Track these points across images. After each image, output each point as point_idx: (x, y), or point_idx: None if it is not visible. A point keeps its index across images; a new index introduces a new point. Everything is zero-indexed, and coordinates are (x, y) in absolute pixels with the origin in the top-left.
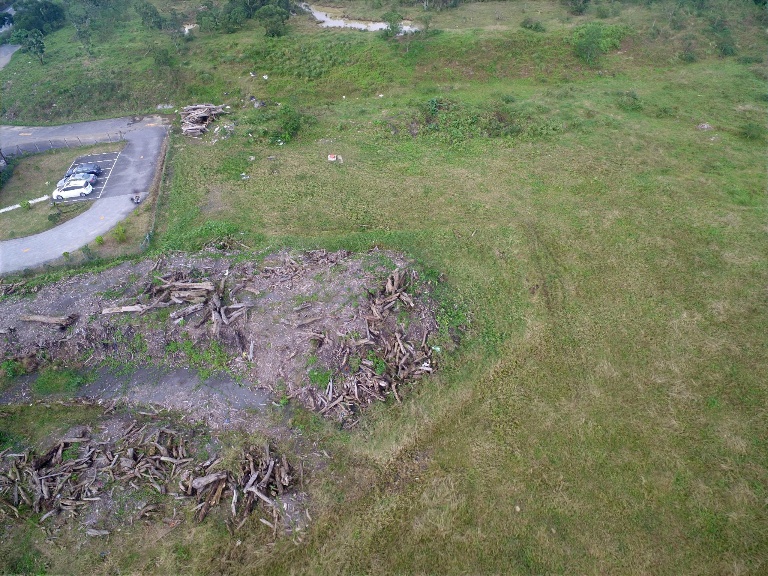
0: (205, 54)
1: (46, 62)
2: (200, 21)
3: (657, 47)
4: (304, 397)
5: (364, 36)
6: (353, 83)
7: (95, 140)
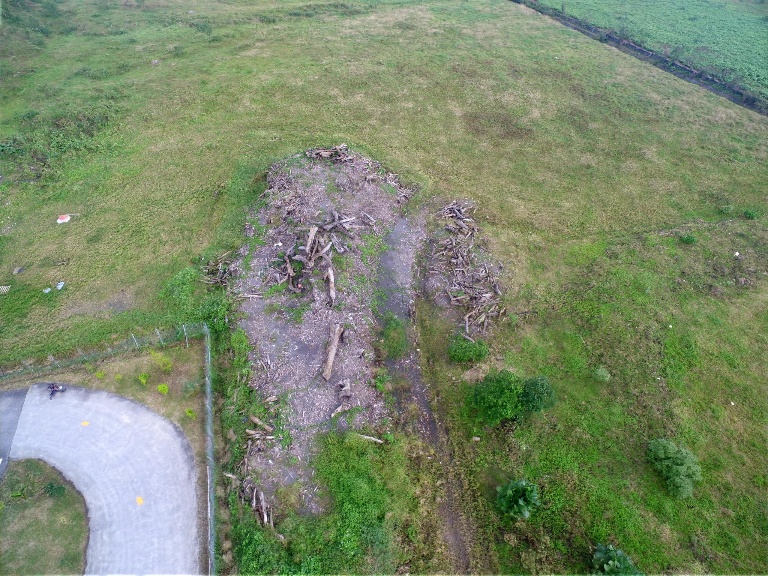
0: None
1: None
2: None
3: (12, 43)
4: None
5: None
6: None
7: None
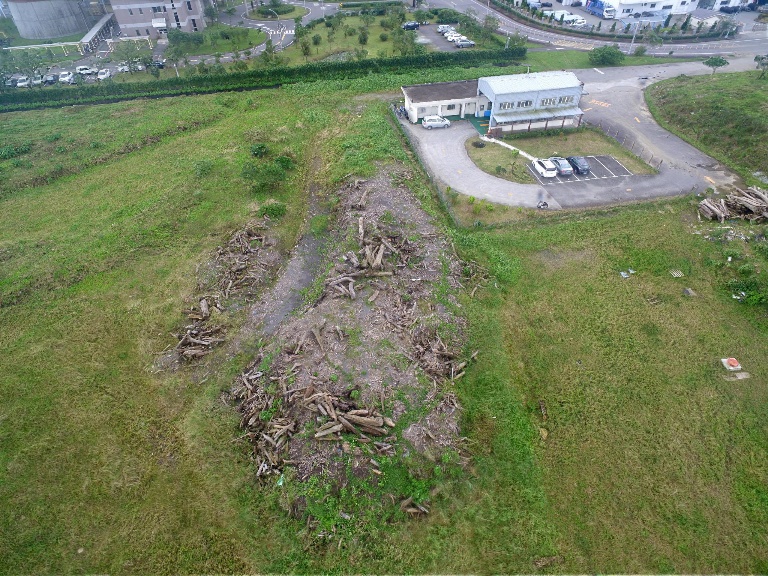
0: None
1: (766, 78)
2: None
3: None
4: None
5: None
6: None
7: None
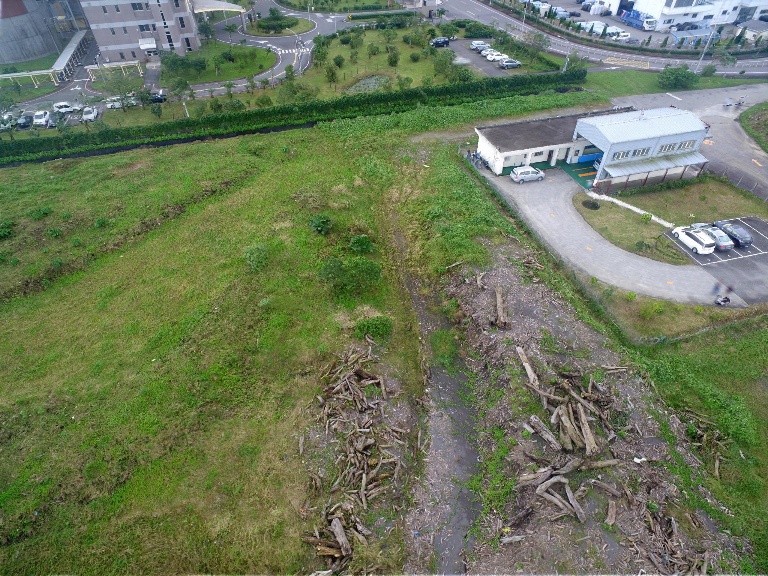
0: None
1: None
2: None
3: None
4: None
5: None
6: None
7: None
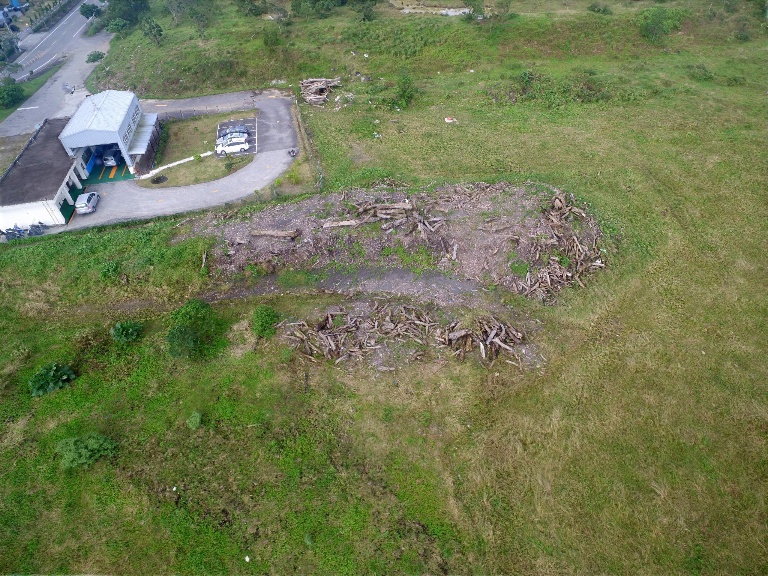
0: (307, 36)
1: (161, 45)
2: (295, 8)
3: (714, 28)
4: (508, 284)
5: (449, 19)
6: (445, 60)
7: (231, 108)
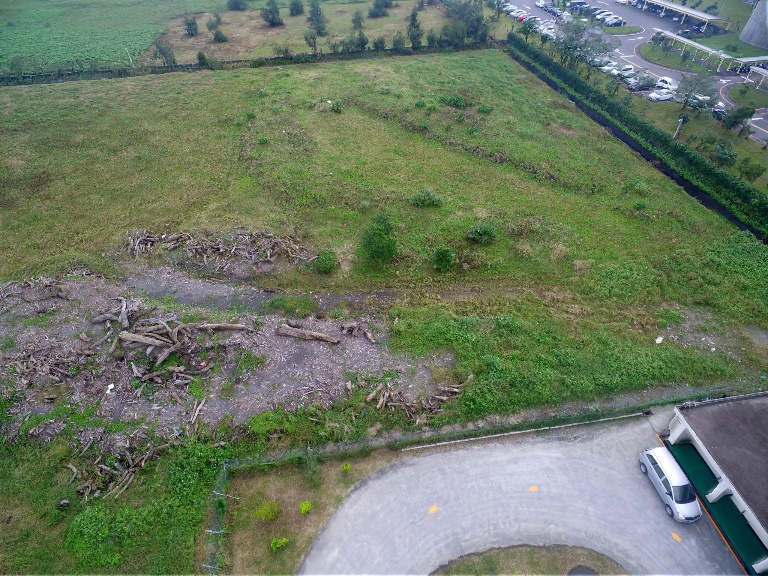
0: None
1: None
2: None
3: None
4: None
5: None
6: None
7: None
